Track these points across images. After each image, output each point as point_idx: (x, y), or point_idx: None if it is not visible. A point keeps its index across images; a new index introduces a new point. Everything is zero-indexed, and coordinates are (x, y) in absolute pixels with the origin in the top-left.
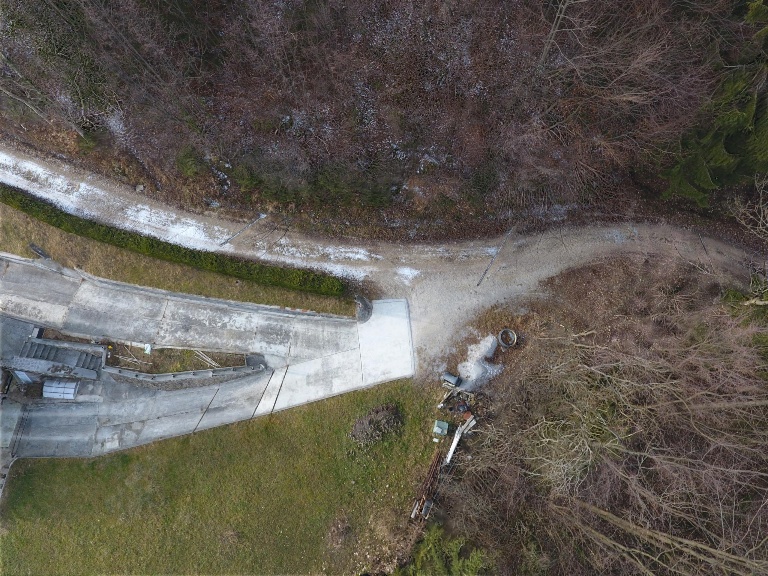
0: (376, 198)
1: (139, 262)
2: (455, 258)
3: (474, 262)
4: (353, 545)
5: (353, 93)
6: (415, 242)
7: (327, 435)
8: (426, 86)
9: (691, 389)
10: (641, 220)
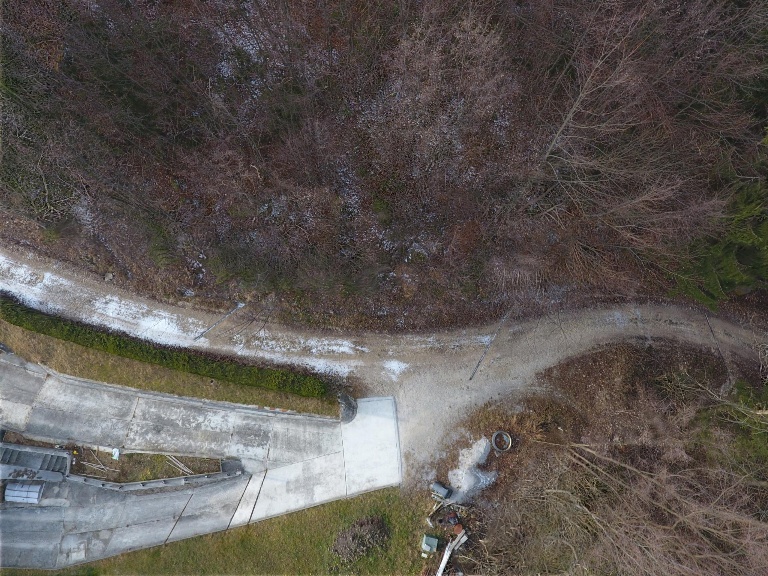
0: (361, 288)
1: (107, 360)
2: (446, 349)
3: (466, 353)
4: None
5: (336, 180)
6: (403, 331)
7: (308, 549)
8: (414, 173)
9: (702, 546)
10: (644, 300)
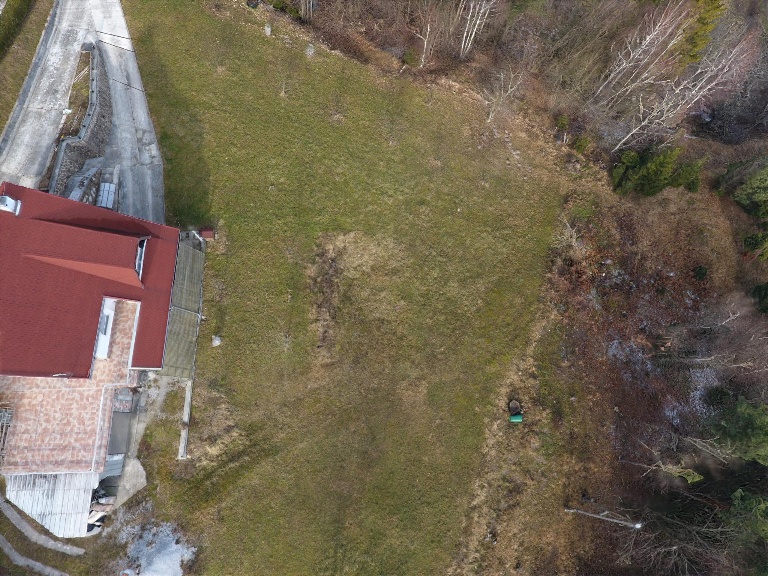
0: None
1: None
2: None
3: None
4: (228, 7)
5: None
6: None
7: (149, 6)
8: None
9: None
10: None
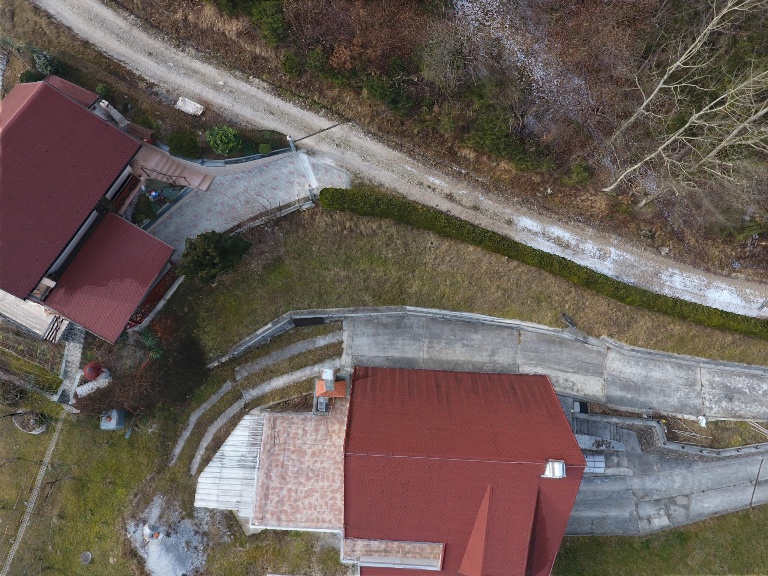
0: None
1: (689, 331)
2: None
3: None
4: None
5: None
6: None
7: None
8: None
9: None
10: None
